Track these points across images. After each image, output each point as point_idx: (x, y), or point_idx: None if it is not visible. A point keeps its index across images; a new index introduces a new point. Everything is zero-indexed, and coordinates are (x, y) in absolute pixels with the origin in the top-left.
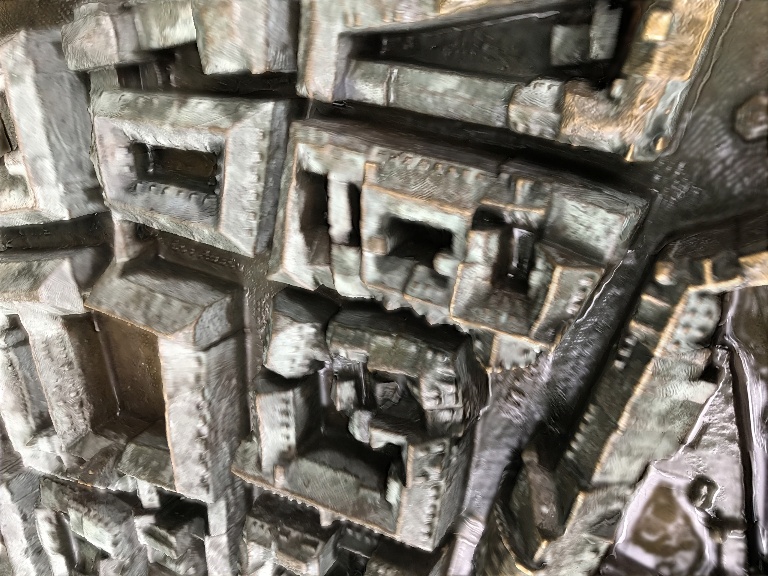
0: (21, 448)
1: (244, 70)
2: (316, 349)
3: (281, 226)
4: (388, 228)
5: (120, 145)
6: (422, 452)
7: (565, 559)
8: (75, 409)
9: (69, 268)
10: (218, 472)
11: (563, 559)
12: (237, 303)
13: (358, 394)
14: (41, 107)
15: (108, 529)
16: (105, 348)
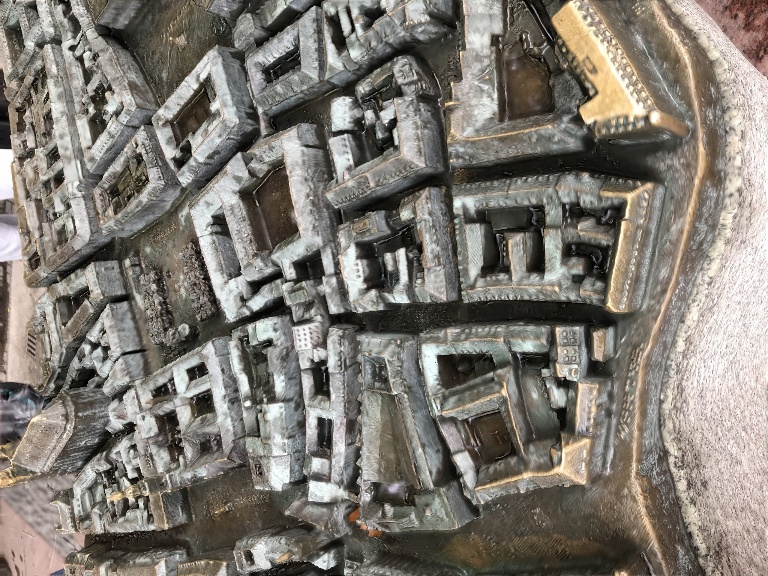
0: (220, 295)
1: (304, 7)
2: (354, 109)
3: (324, 46)
4: (364, 14)
5: (258, 70)
6: (401, 100)
7: (472, 101)
8: (248, 244)
9: (240, 155)
10: (323, 226)
11: (471, 101)
12: (321, 132)
13: (376, 115)
14: (225, 74)
15: (270, 319)
16: (262, 215)
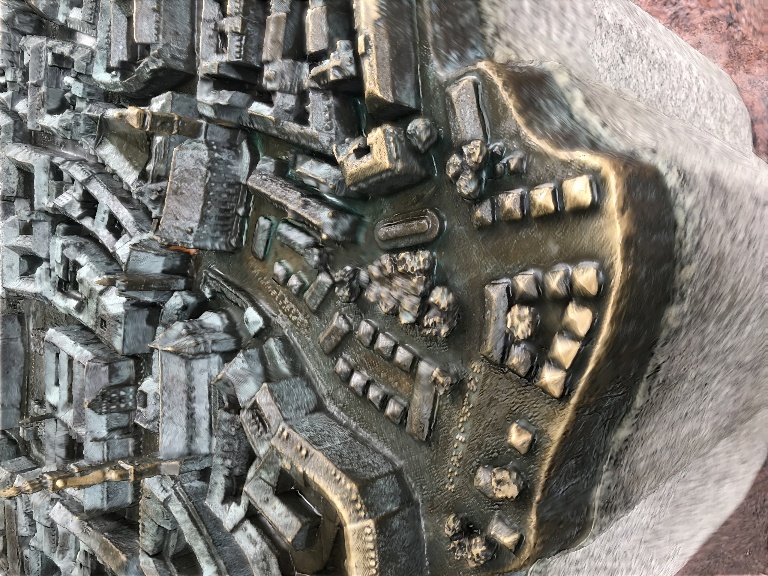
0: None
1: None
2: None
3: None
4: None
5: None
6: None
7: None
8: None
9: None
10: None
11: None
12: None
13: None
14: None
15: None
16: None
